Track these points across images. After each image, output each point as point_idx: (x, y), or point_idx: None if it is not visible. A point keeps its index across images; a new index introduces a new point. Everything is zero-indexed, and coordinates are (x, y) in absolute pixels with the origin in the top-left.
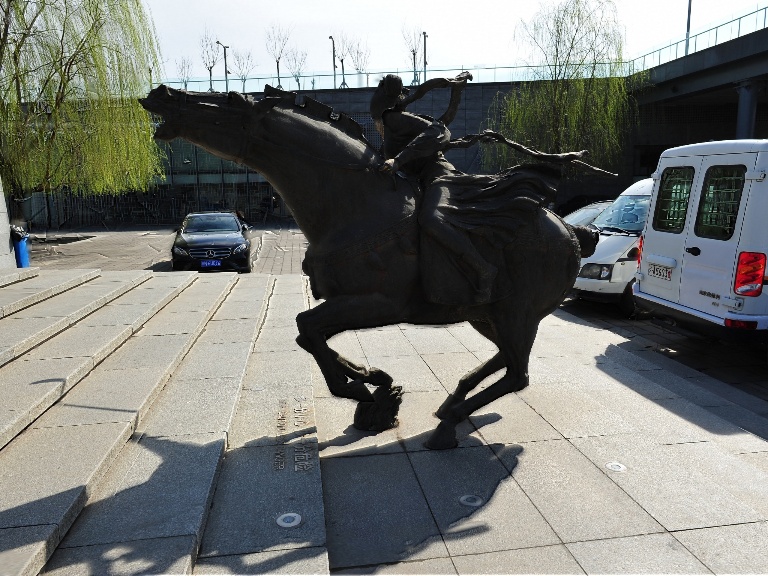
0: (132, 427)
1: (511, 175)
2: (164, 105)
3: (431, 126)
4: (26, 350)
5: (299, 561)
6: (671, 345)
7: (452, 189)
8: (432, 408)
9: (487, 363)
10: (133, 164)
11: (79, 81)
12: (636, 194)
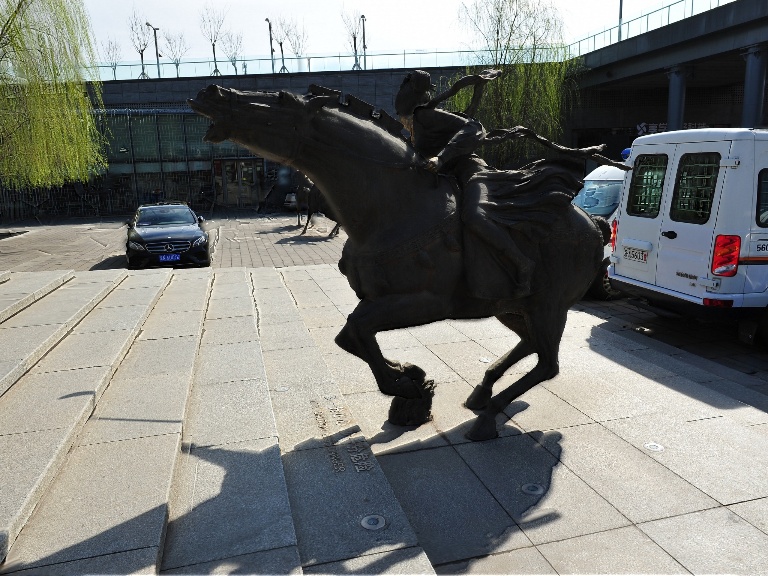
0: (181, 438)
1: (542, 170)
2: (215, 106)
3: (469, 123)
4: (35, 362)
5: (401, 563)
6: (644, 324)
7: (489, 185)
8: (459, 399)
9: (511, 353)
10: (69, 154)
11: (7, 66)
12: (599, 179)
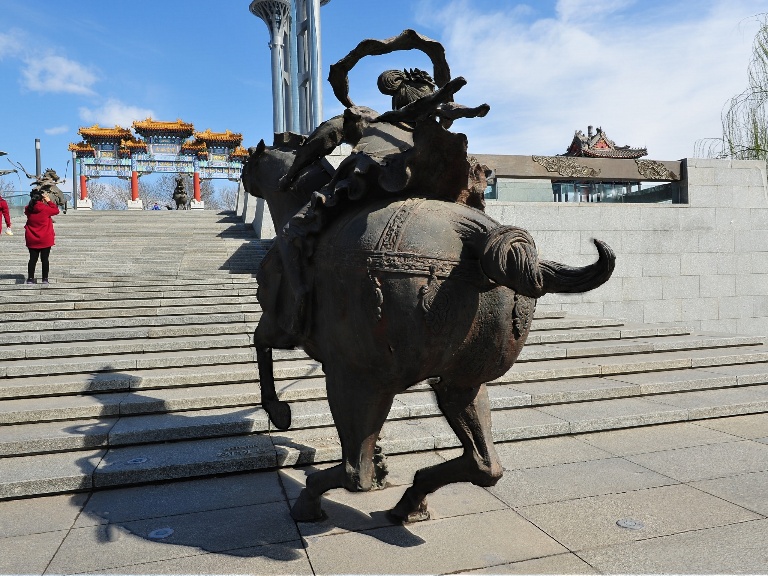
0: None
1: None
2: None
3: None
4: None
5: None
6: None
7: None
8: None
9: None
10: None
11: None
12: None
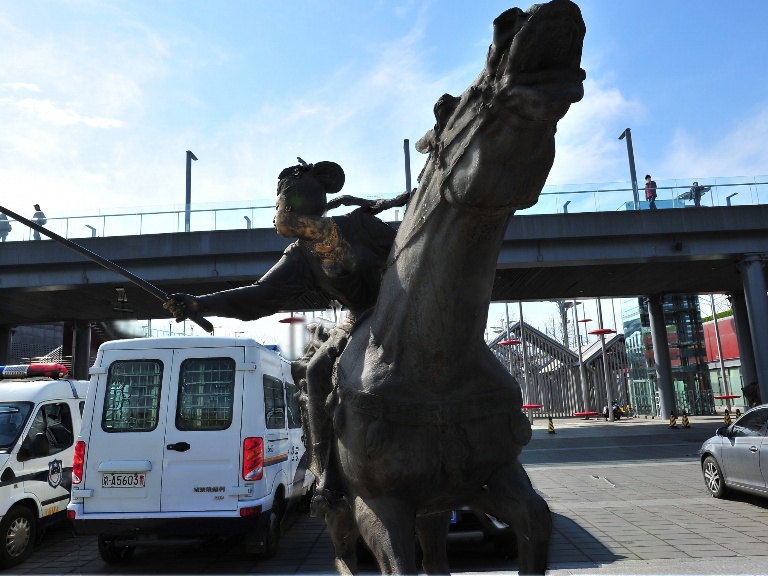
0: None
1: None
2: None
3: None
4: None
5: None
6: (112, 575)
7: None
8: None
9: None
10: None
11: None
12: None
